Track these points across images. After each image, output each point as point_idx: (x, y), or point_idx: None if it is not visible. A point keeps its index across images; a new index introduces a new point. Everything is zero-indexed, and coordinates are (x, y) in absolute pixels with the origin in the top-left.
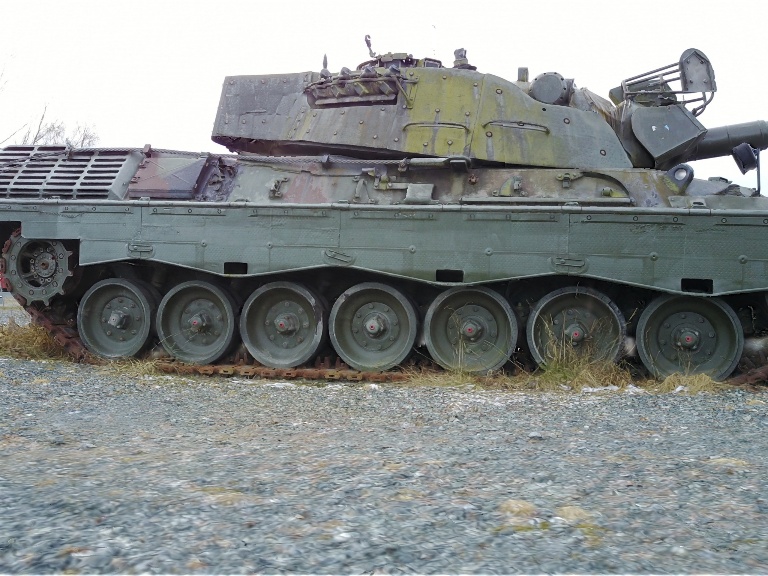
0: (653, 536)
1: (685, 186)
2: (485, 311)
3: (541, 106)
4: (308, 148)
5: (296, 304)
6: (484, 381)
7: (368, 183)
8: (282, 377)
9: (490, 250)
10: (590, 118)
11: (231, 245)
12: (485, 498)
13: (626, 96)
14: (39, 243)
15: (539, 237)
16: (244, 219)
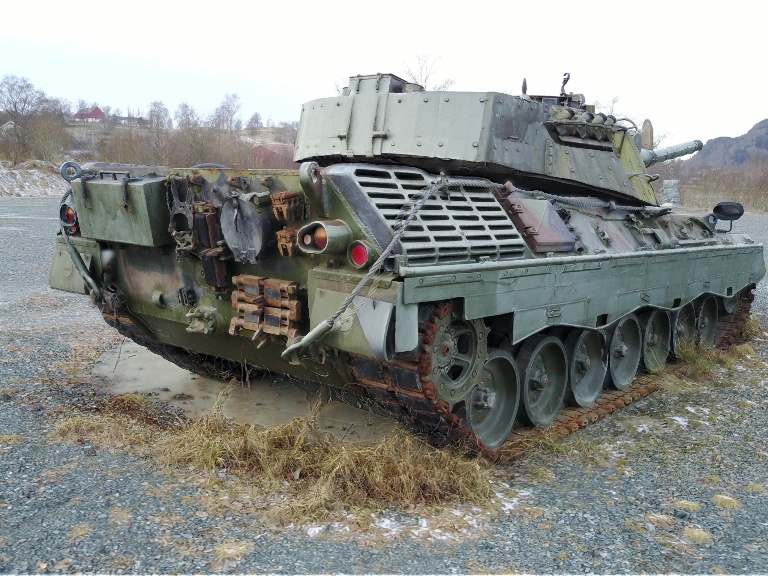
0: None
1: None
2: None
3: None
4: (566, 186)
5: None
6: None
7: None
8: (608, 413)
9: None
10: None
11: None
12: None
13: None
14: None
15: None
16: (609, 271)
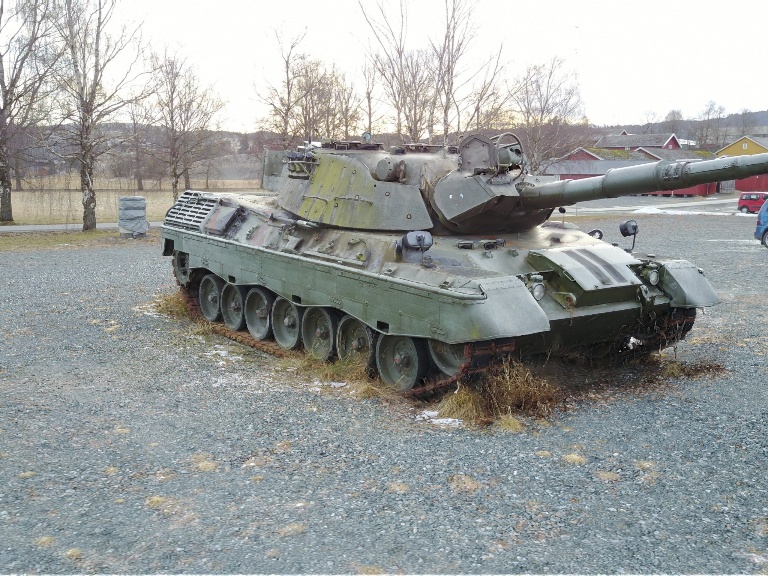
0: None
1: (398, 255)
2: None
3: (374, 183)
4: None
5: None
6: None
7: (283, 233)
8: None
9: (309, 286)
10: (406, 190)
11: (230, 266)
12: (3, 422)
13: (458, 165)
14: None
15: None
16: None
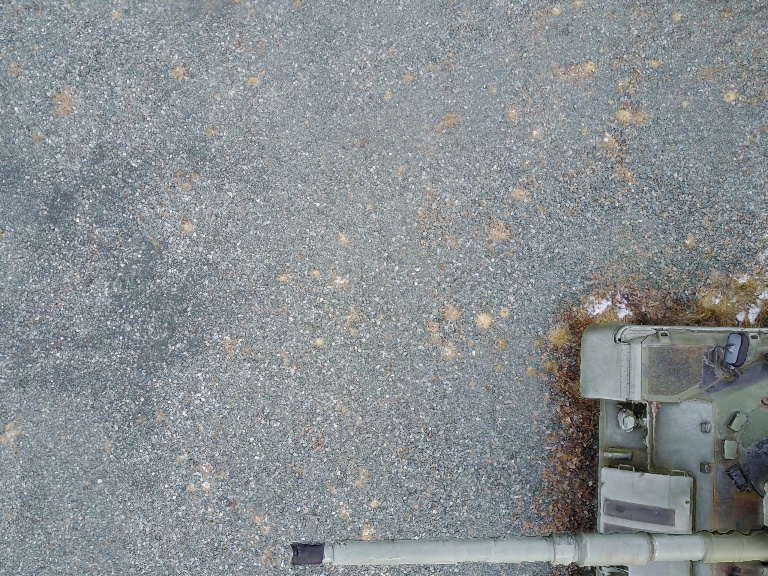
0: (763, 9)
1: None
2: None
3: None
4: None
5: None
6: None
7: None
8: None
9: None
10: None
11: None
12: None
13: None
14: None
15: None
16: None
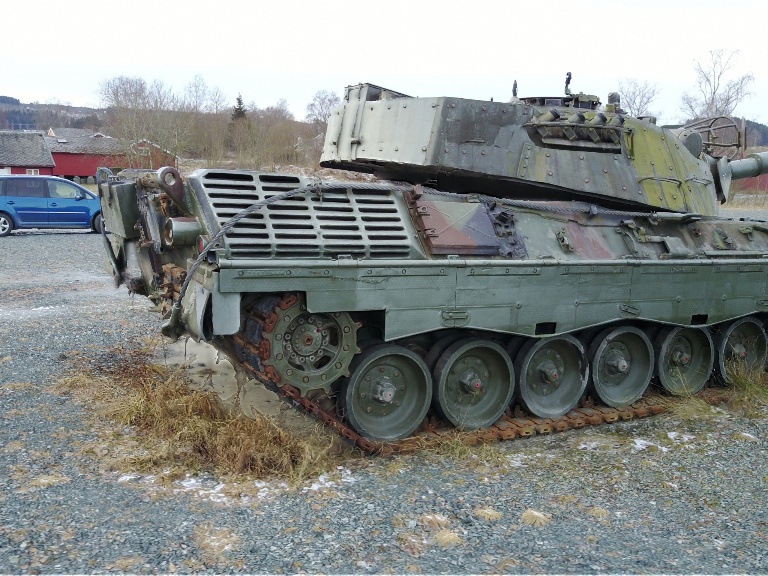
0: None
1: None
2: (685, 340)
3: None
4: (545, 190)
5: (554, 351)
6: (706, 401)
7: None
8: (572, 428)
9: (725, 296)
10: None
11: (543, 305)
12: None
13: None
14: (305, 314)
15: (752, 284)
16: (556, 278)
